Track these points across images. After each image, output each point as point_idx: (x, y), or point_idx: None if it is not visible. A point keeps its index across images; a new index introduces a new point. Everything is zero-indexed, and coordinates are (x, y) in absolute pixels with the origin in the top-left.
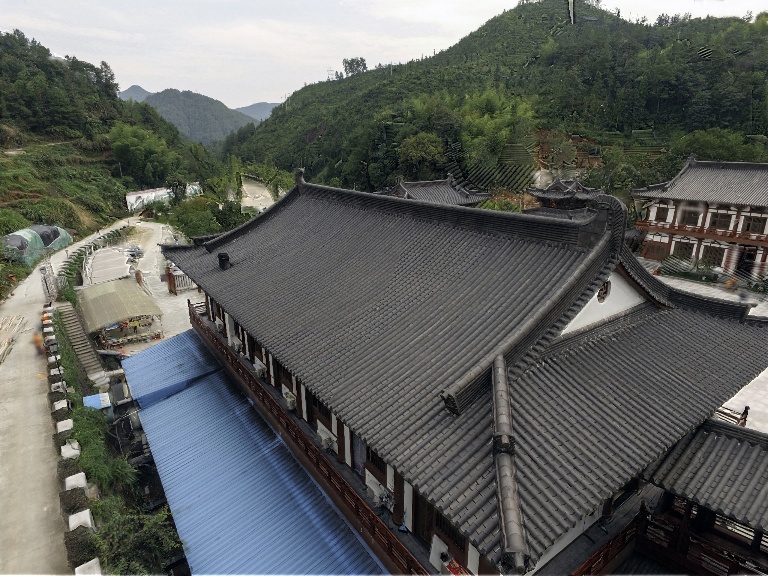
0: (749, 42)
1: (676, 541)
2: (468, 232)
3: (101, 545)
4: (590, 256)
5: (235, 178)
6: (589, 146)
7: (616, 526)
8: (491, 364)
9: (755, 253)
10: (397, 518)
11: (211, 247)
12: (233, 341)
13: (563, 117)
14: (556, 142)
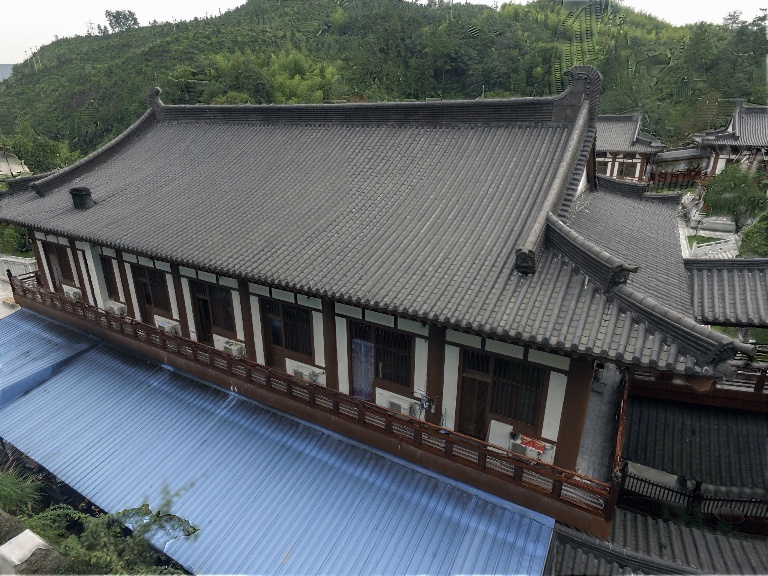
0: None
1: None
2: (420, 128)
3: (99, 558)
4: (580, 123)
5: None
6: None
7: (608, 378)
8: (546, 221)
9: None
10: None
11: (43, 189)
12: (110, 305)
13: None
14: None
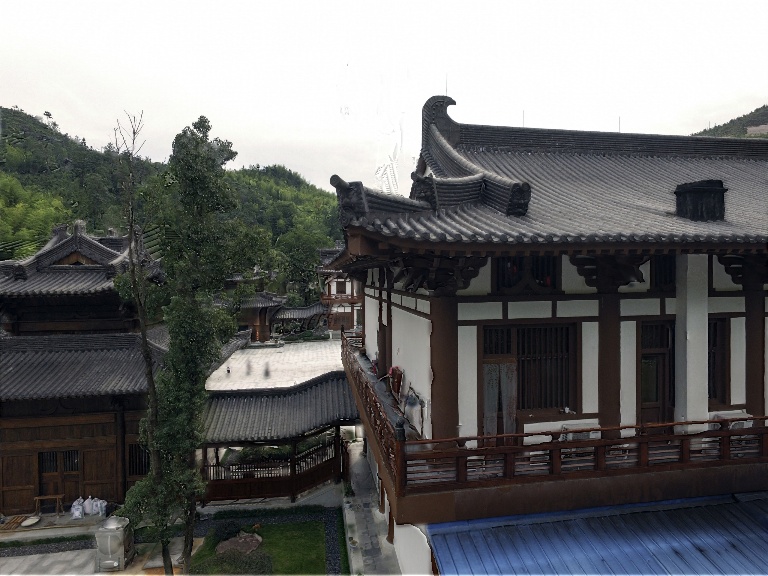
0: None
1: None
2: None
3: None
4: None
5: None
6: None
7: None
8: None
9: None
10: None
11: None
12: (731, 417)
13: None
14: None
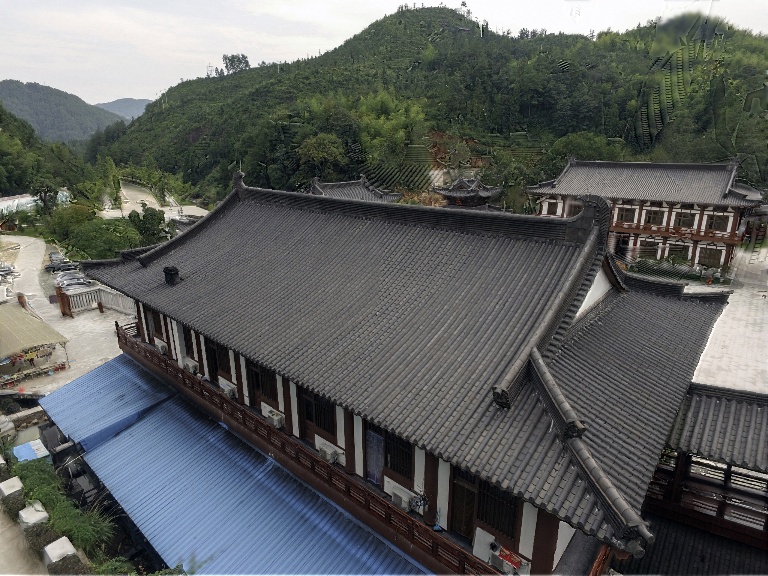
0: (595, 57)
1: (671, 493)
2: (449, 232)
3: None
4: (586, 250)
5: (112, 182)
6: (481, 147)
7: None
8: (529, 357)
9: (628, 239)
10: (429, 519)
11: (146, 261)
12: (186, 363)
13: (450, 120)
14: (451, 143)
